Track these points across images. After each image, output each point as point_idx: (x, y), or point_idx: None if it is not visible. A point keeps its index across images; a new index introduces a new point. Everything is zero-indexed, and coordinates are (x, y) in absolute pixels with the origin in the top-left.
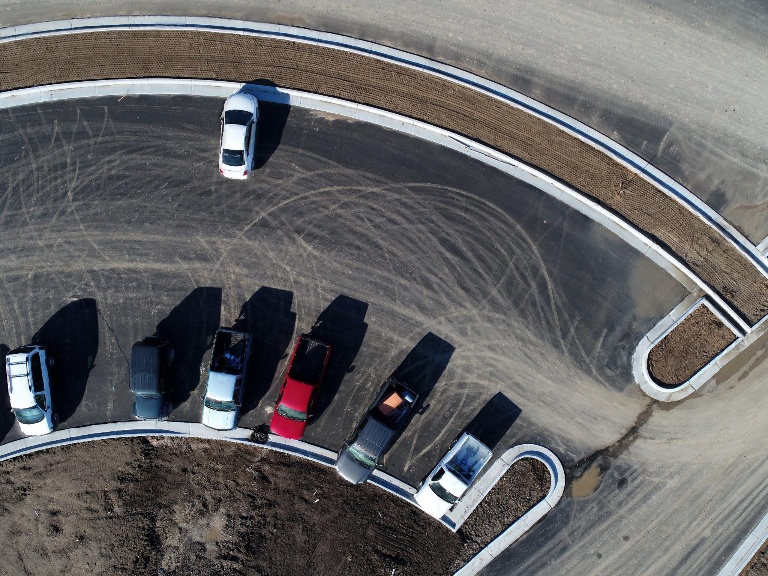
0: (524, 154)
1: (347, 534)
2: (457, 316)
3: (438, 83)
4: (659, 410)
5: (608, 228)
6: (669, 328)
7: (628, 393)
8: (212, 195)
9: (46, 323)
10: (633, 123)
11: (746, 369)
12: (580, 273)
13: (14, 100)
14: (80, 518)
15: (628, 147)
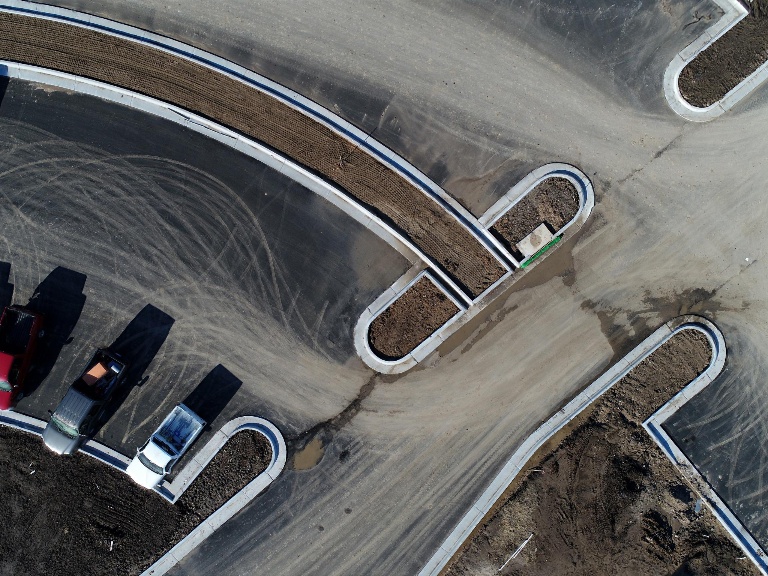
0: (244, 126)
1: (63, 506)
2: (177, 288)
3: (157, 55)
4: (382, 383)
5: (329, 200)
6: (390, 300)
7: (350, 365)
8: None
9: None
10: (353, 96)
11: (469, 342)
12: (301, 245)
13: None
14: None
15: (348, 120)
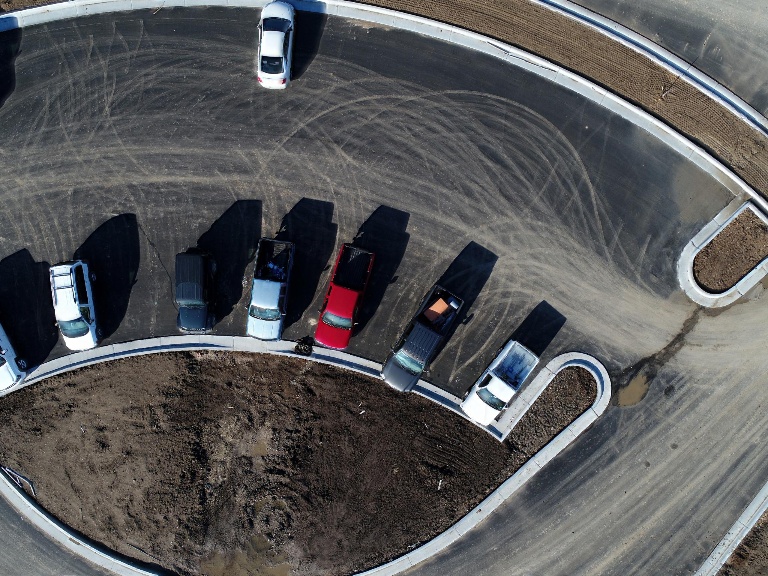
0: (564, 59)
1: (393, 445)
2: (499, 224)
3: None
4: (705, 316)
5: (651, 132)
6: (714, 232)
7: (674, 300)
8: (250, 107)
9: (87, 239)
10: (675, 25)
11: None
12: (623, 179)
13: (49, 15)
14: (126, 434)
15: (670, 49)
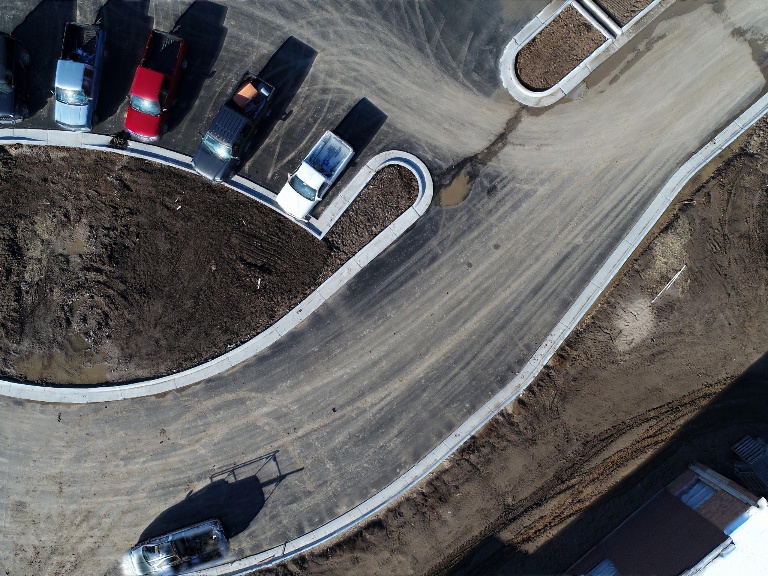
0: None
1: (210, 242)
2: (319, 19)
3: None
4: (528, 116)
5: None
6: (537, 29)
7: (496, 98)
8: None
9: None
10: None
11: (617, 72)
12: None
13: None
14: None
15: None
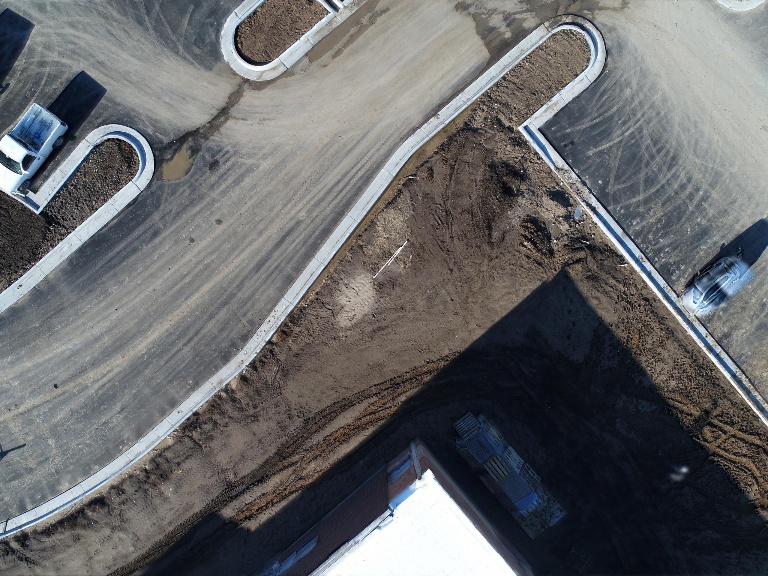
0: None
1: None
2: None
3: None
4: (251, 90)
5: None
6: (257, 2)
7: (218, 72)
8: None
9: None
10: None
11: (340, 46)
12: None
13: None
14: None
15: None
